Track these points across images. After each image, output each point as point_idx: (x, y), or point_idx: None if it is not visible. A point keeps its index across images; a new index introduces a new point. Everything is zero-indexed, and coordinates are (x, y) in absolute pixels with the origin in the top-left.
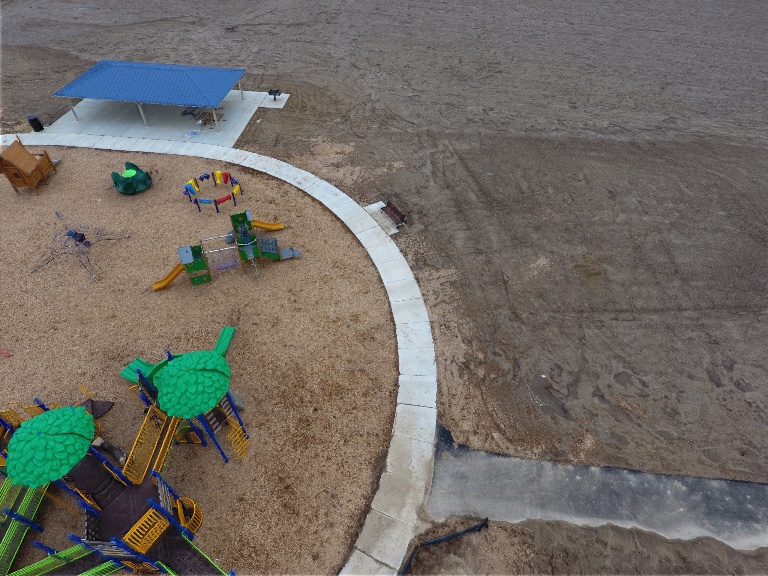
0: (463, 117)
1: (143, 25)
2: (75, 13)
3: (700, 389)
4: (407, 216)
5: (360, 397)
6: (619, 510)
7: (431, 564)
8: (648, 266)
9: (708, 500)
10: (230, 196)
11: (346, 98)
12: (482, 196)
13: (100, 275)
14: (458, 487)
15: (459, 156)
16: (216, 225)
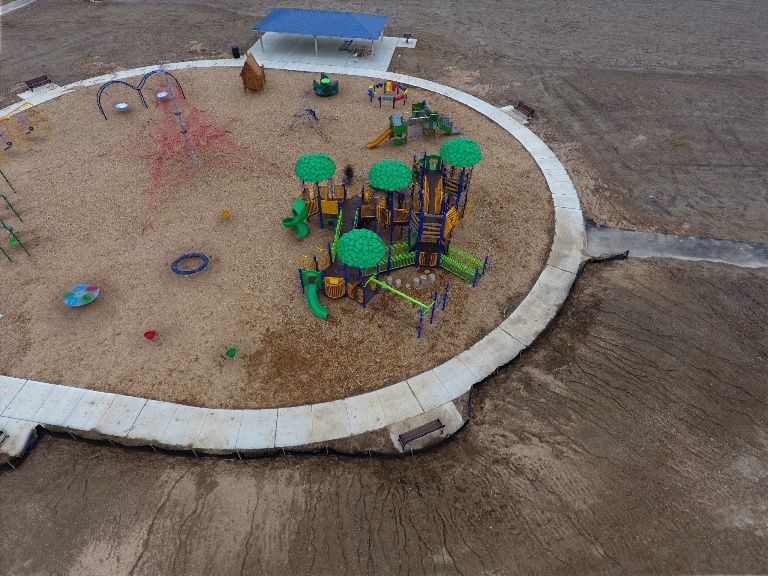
0: (558, 57)
1: None
2: None
3: (760, 205)
4: (533, 114)
5: (529, 203)
6: (710, 255)
7: (597, 270)
8: (719, 141)
9: (767, 253)
10: (403, 96)
11: (461, 43)
12: (588, 102)
13: (328, 139)
14: (604, 243)
15: (564, 79)
16: None
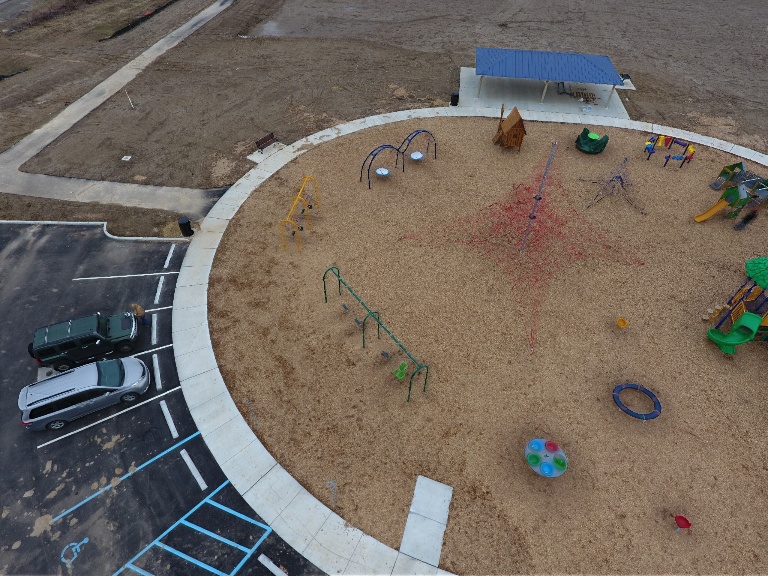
0: None
1: (422, 22)
2: (350, 12)
3: None
4: None
5: None
6: None
7: None
8: None
9: None
10: (692, 154)
11: (675, 82)
12: None
13: (642, 211)
14: None
15: None
16: (689, 177)
